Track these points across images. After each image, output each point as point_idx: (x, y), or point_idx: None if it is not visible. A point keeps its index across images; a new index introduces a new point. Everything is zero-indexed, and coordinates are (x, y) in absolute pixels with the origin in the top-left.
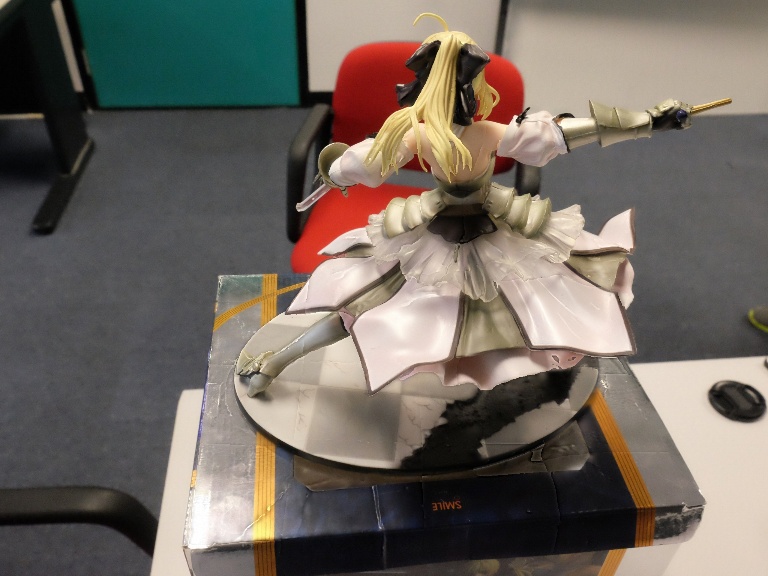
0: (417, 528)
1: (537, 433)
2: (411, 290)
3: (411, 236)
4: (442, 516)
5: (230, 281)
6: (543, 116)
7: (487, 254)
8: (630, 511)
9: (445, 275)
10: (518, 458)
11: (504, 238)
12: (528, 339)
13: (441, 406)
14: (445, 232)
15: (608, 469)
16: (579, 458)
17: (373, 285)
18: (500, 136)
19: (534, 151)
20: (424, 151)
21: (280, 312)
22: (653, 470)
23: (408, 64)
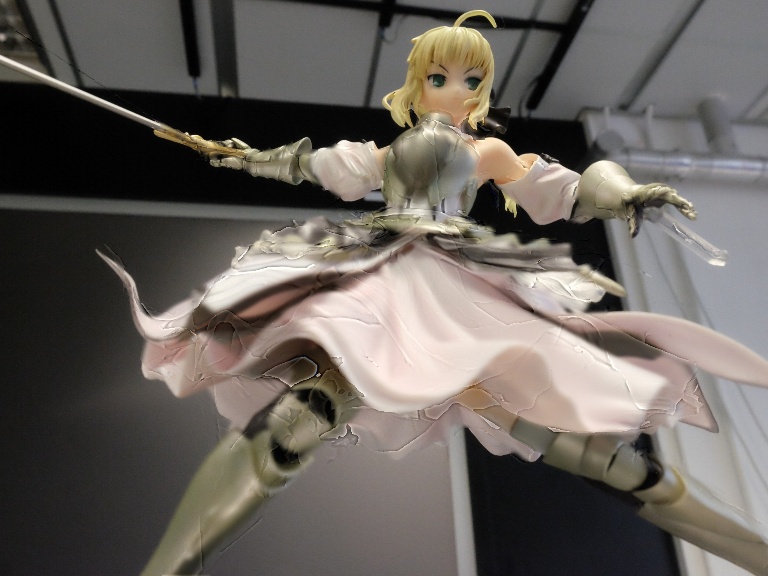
0: None
1: None
2: None
3: None
4: None
5: None
6: None
7: None
8: None
9: None
10: None
11: None
12: None
13: None
14: None
15: None
16: None
17: None
18: None
19: None
20: None
21: None
22: None
23: None
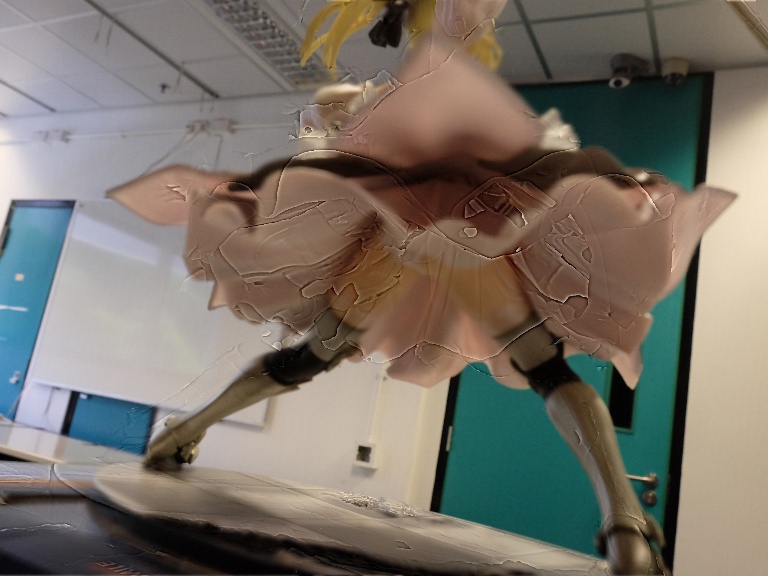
0: (28, 560)
1: None
2: None
3: None
4: (94, 571)
5: None
6: None
7: None
8: None
9: None
10: None
11: None
12: None
13: (319, 538)
14: None
15: None
16: None
17: None
18: None
19: None
20: None
21: None
22: None
23: None
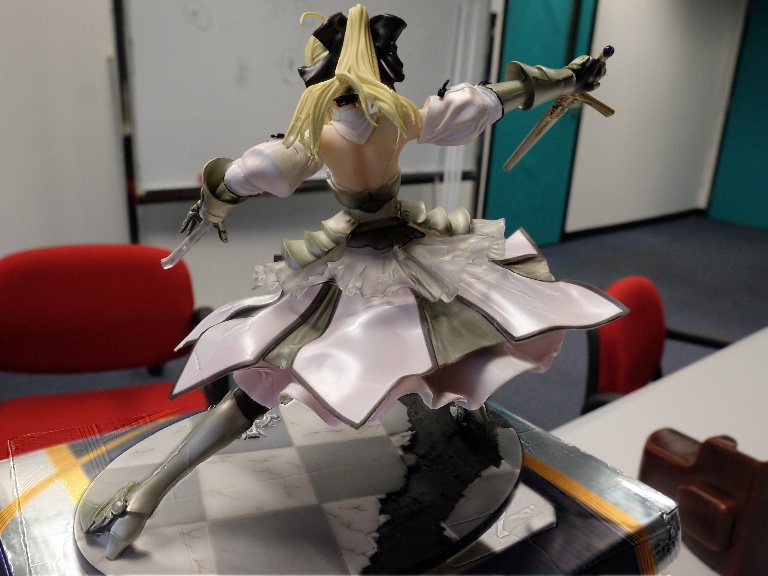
0: None
1: (494, 500)
2: (350, 313)
3: (325, 263)
4: None
5: (26, 440)
6: (467, 84)
7: (427, 256)
8: (628, 551)
9: (396, 277)
10: (487, 534)
11: (436, 242)
12: (507, 332)
13: (374, 503)
14: (372, 242)
15: (581, 517)
16: (546, 516)
17: (292, 327)
18: (421, 117)
19: (467, 118)
20: (333, 150)
21: (115, 458)
22: (621, 505)
23: (318, 32)
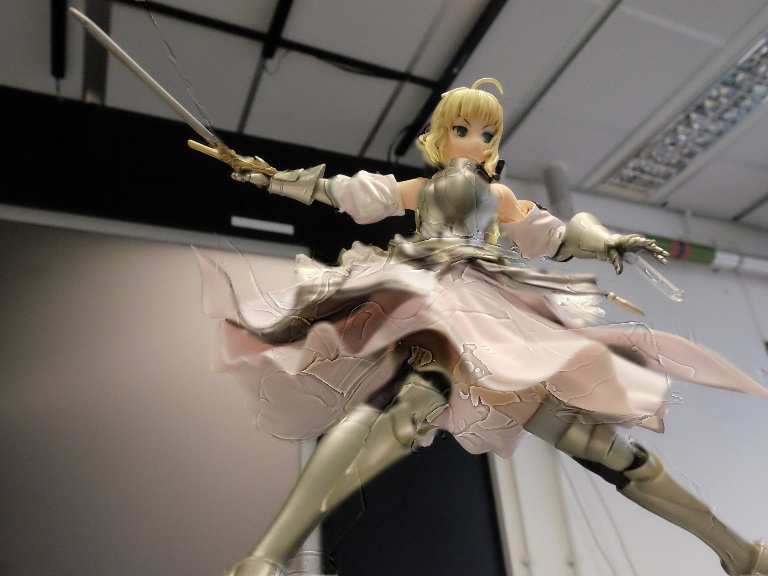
0: None
1: None
2: None
3: None
4: None
5: None
6: None
7: None
8: None
9: None
10: None
11: None
12: None
13: None
14: None
15: None
16: None
17: None
18: None
19: None
20: None
21: None
22: None
23: None
